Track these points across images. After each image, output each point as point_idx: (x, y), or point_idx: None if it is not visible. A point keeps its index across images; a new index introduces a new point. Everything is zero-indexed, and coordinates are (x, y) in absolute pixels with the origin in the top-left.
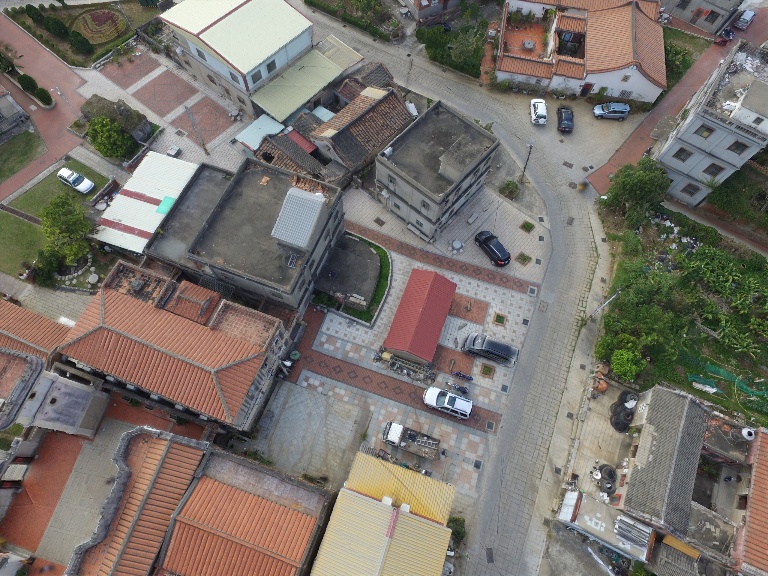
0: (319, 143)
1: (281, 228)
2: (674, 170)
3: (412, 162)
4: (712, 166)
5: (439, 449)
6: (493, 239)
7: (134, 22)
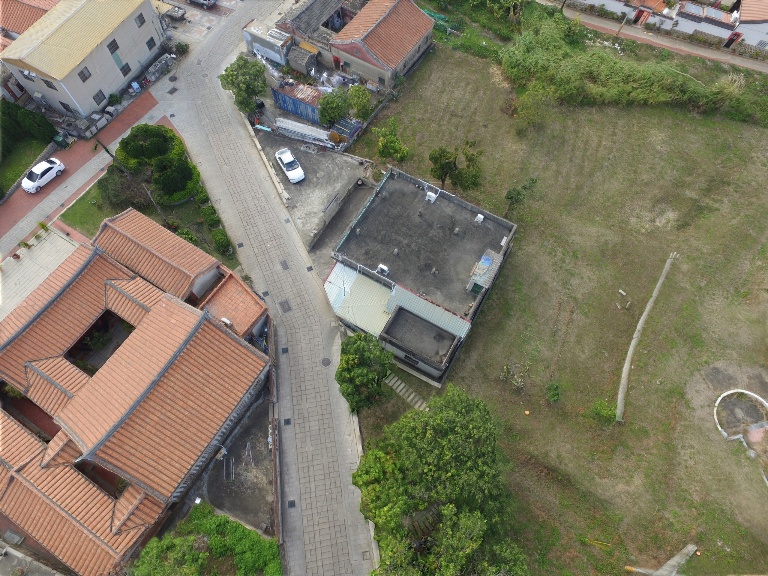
0: None
1: None
2: None
3: None
4: None
5: (187, 20)
6: None
7: None
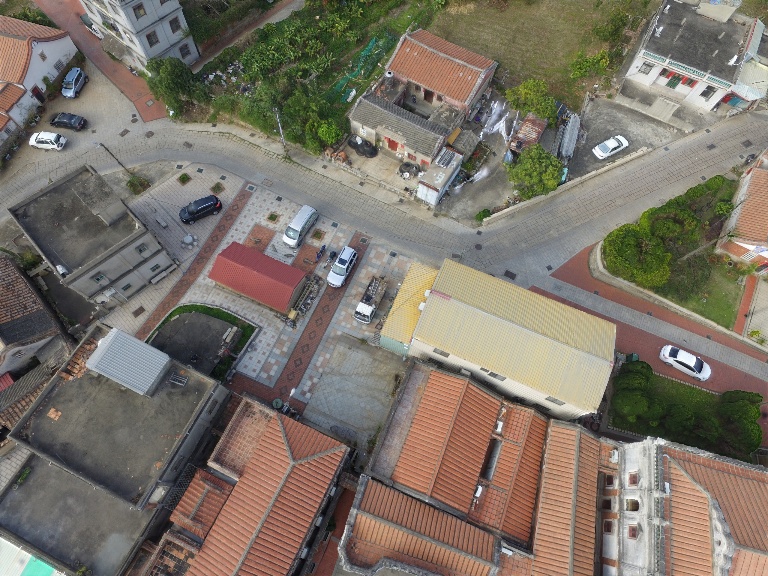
0: (3, 367)
1: (137, 382)
2: (163, 53)
3: (84, 249)
4: (171, 24)
5: None
6: (192, 206)
7: None
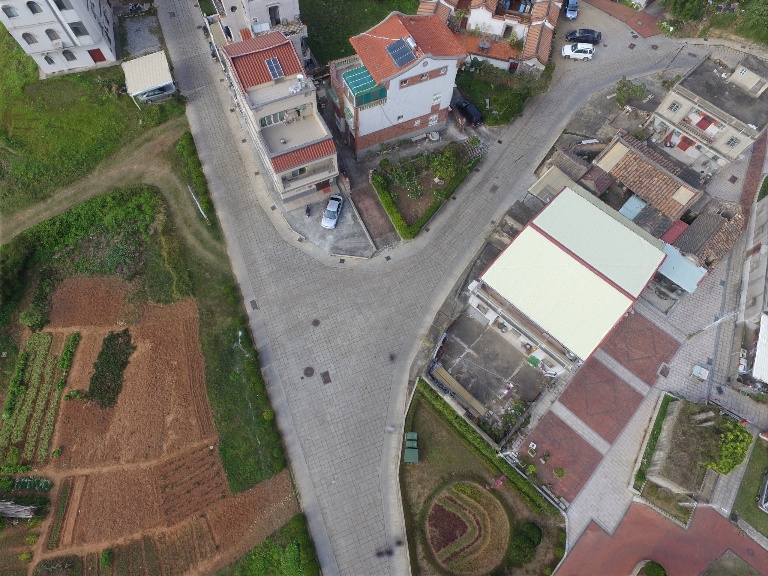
0: None
1: None
2: None
3: (750, 114)
4: None
5: None
6: None
7: (452, 470)
